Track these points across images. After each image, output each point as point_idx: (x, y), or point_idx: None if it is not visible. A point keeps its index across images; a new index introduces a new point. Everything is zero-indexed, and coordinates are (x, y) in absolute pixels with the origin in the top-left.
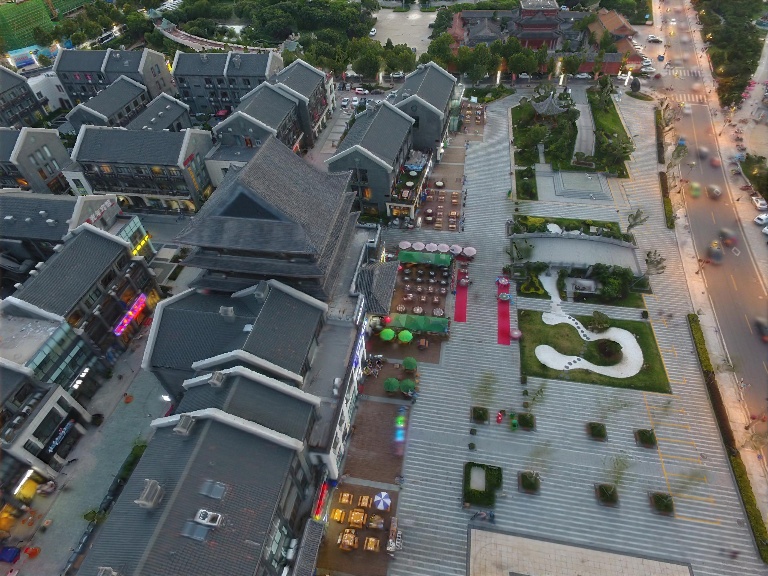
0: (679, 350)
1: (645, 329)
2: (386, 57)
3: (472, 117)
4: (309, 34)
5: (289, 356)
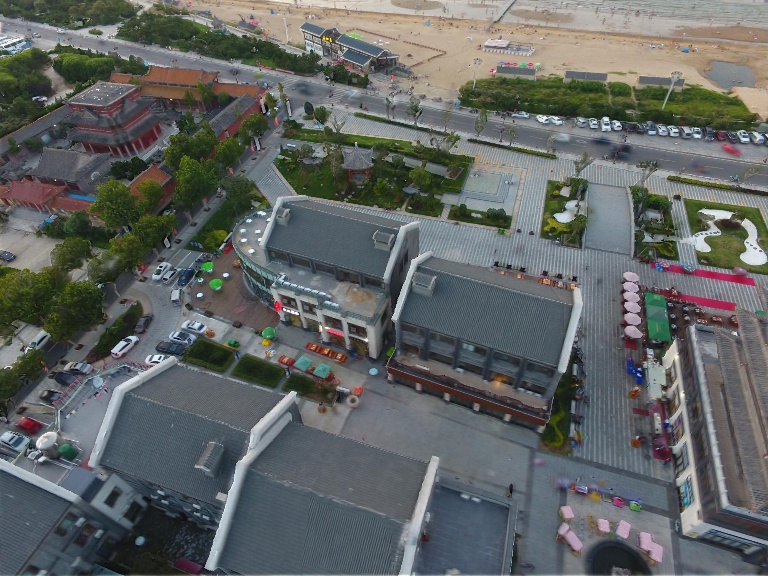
0: (709, 194)
1: (695, 201)
2: (90, 273)
3: None
4: None
5: None
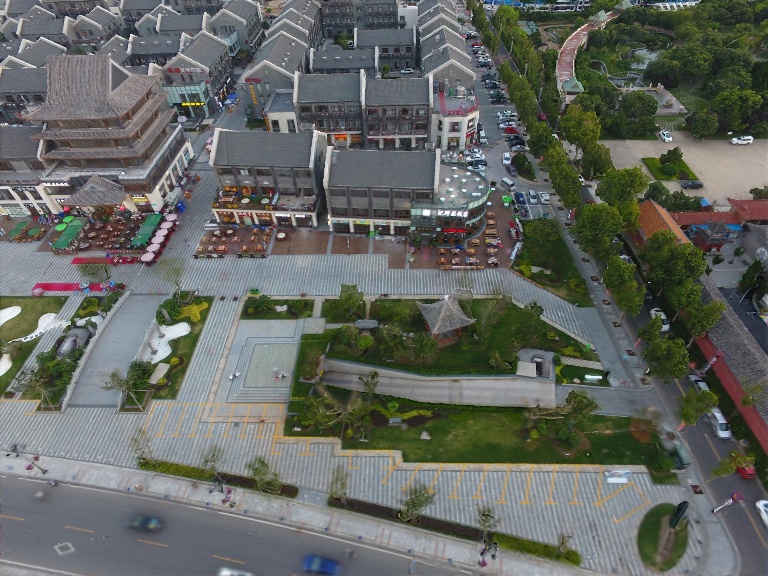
0: None
1: None
2: None
3: (461, 256)
4: (691, 98)
5: (2, 150)
